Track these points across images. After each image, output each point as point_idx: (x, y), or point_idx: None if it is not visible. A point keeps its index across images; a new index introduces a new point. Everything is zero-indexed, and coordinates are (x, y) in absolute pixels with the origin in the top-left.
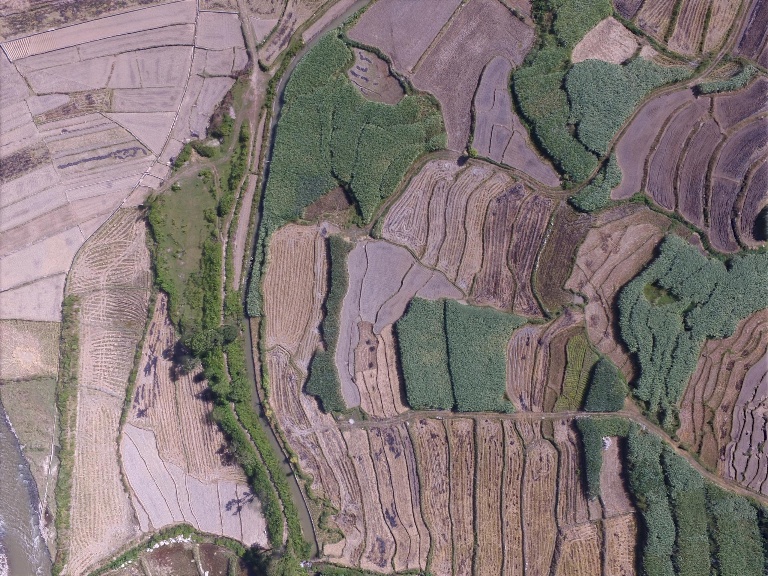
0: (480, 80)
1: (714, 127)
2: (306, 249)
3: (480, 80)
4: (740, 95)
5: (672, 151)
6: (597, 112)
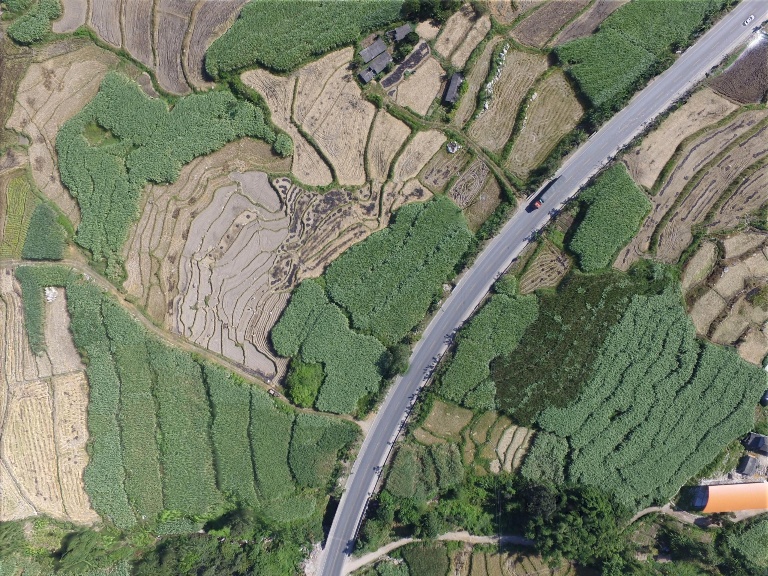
0: None
1: None
2: None
3: None
4: None
5: None
6: None
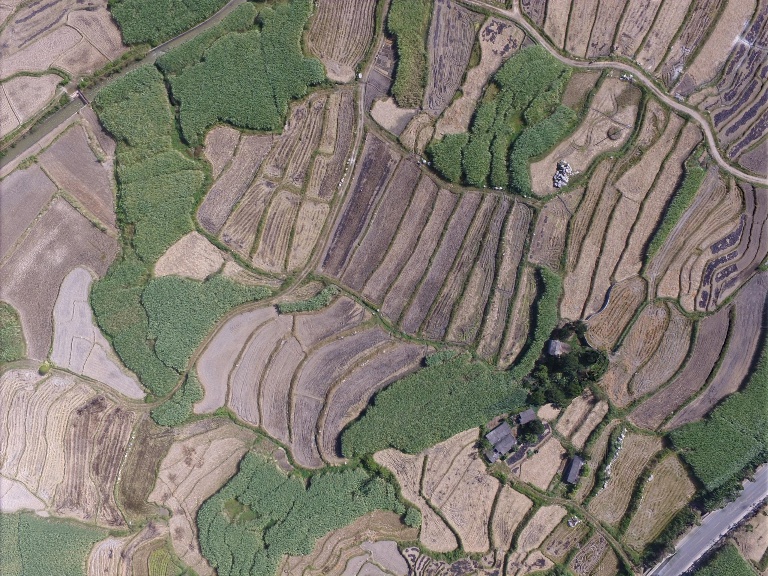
0: (59, 291)
1: (296, 345)
2: None
3: (59, 291)
4: (322, 314)
5: (255, 367)
6: (174, 329)
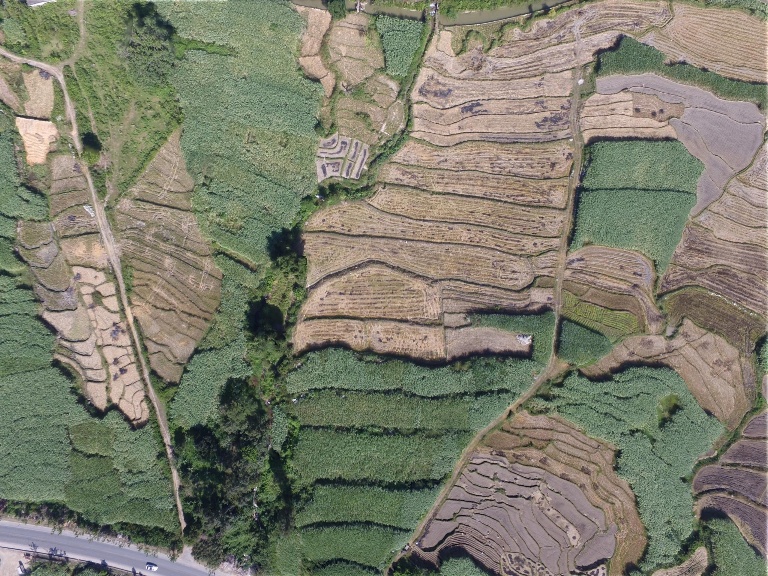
0: None
1: None
2: (767, 62)
3: None
4: None
5: None
6: None
